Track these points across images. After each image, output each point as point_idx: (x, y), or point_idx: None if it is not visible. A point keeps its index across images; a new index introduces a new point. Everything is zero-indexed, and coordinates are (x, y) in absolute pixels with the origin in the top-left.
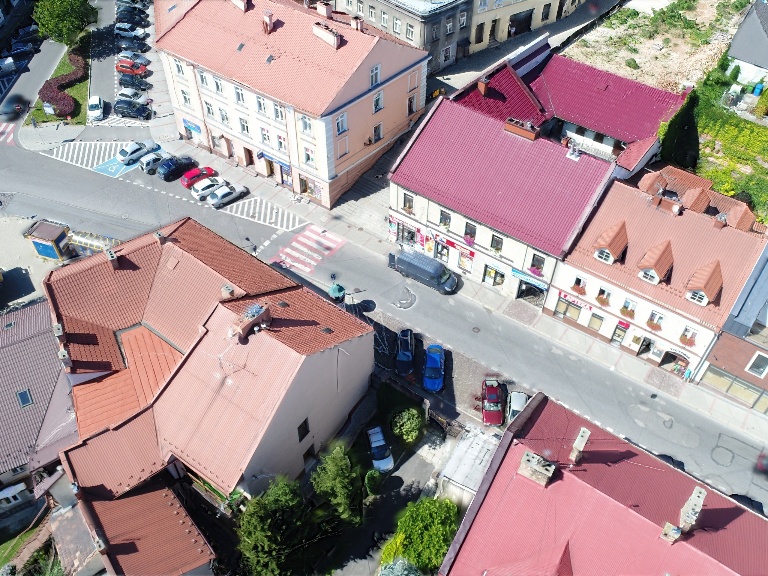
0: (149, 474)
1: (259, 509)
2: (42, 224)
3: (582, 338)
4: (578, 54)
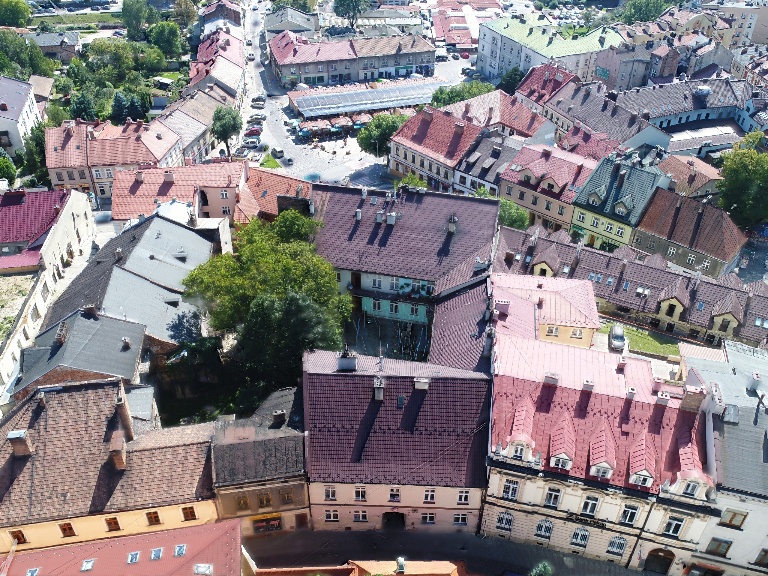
0: None
1: None
2: None
3: None
4: (24, 284)
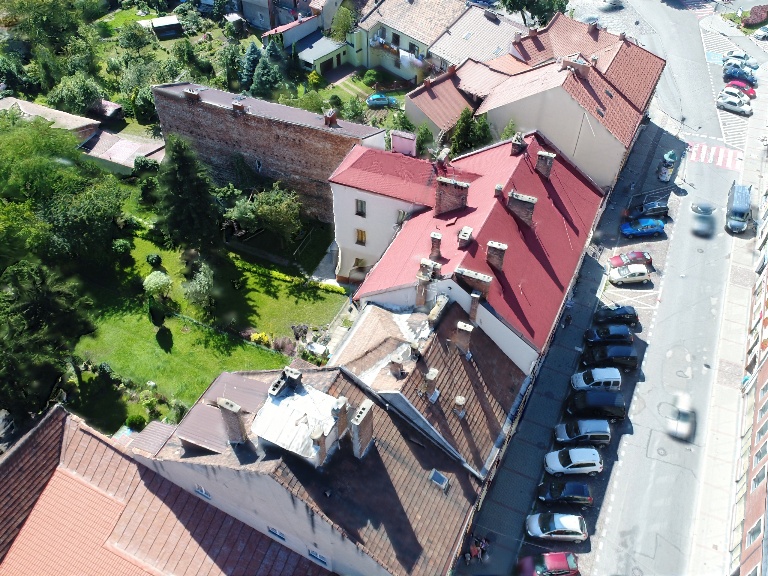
0: (475, 93)
1: (466, 112)
2: (632, 39)
3: (742, 316)
4: None
